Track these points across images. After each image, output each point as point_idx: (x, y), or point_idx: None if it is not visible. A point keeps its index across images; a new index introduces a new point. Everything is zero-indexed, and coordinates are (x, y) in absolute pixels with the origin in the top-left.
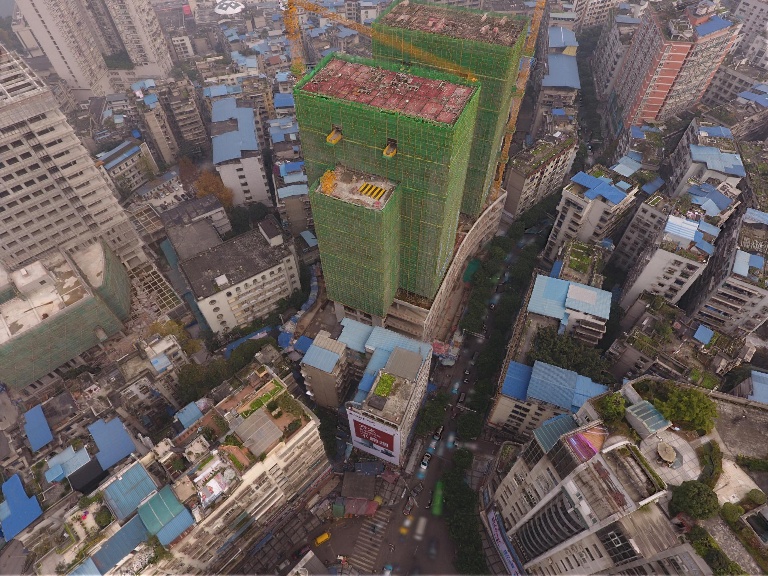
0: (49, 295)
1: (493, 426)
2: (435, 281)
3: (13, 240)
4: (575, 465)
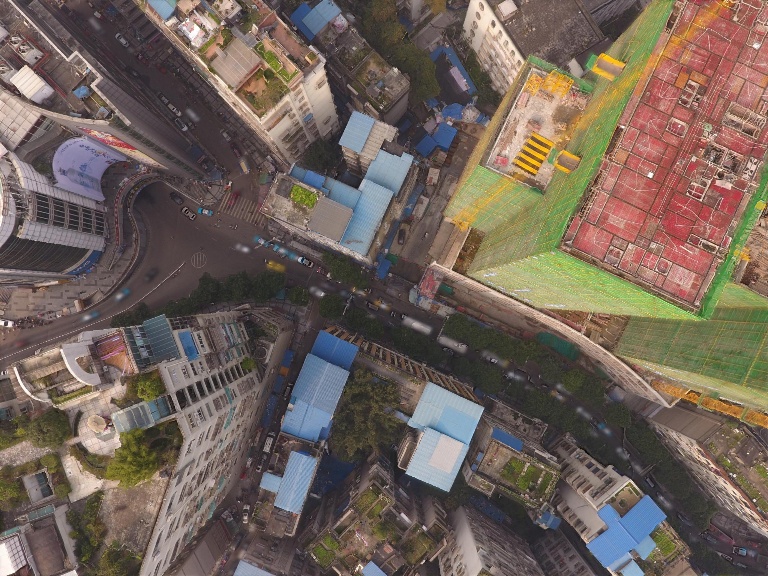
0: None
1: None
2: None
3: None
4: None
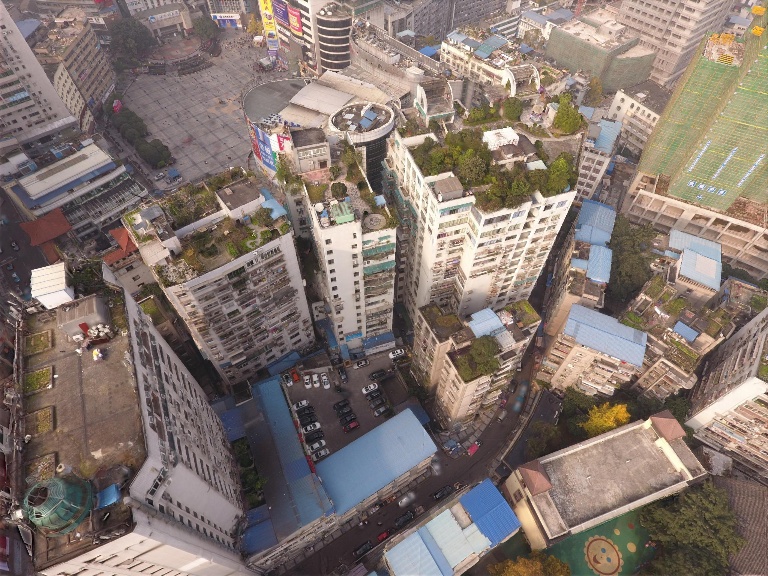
0: (603, 39)
1: None
2: (680, 176)
3: (634, 7)
4: None
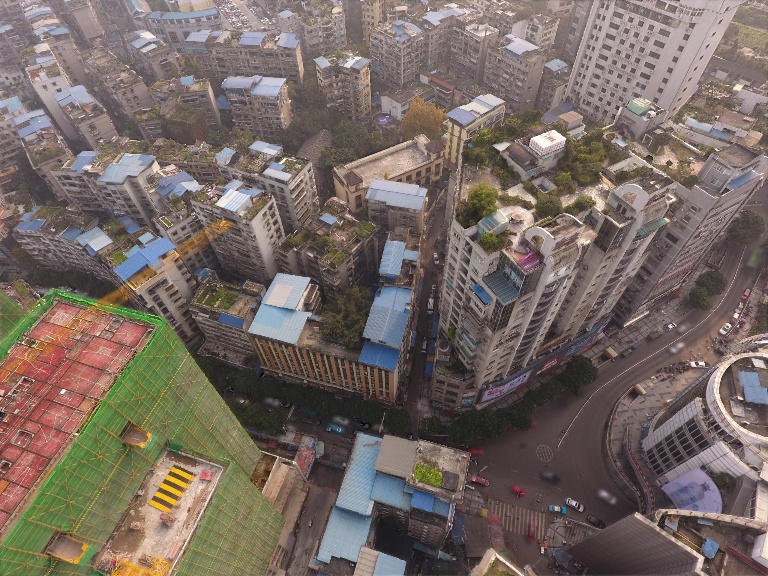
0: None
1: (395, 398)
2: None
3: None
4: None
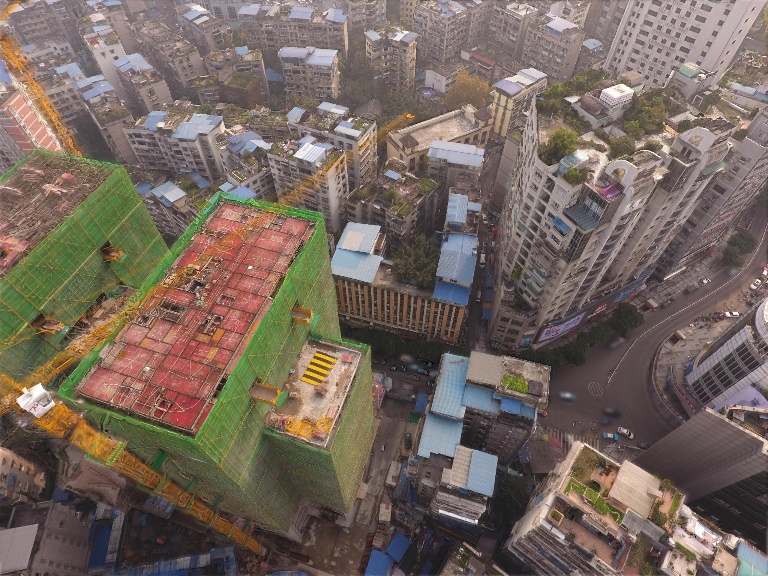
0: None
1: None
2: None
3: None
4: (621, 199)
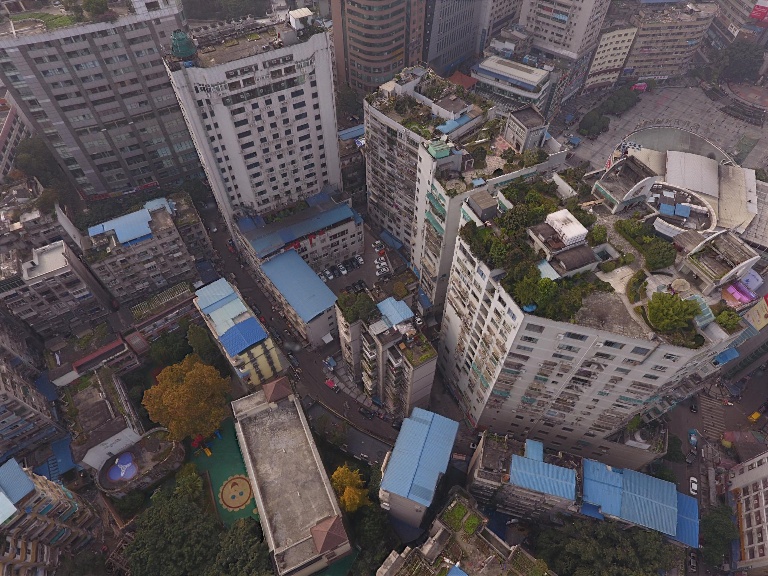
0: None
1: None
2: None
3: None
4: None
